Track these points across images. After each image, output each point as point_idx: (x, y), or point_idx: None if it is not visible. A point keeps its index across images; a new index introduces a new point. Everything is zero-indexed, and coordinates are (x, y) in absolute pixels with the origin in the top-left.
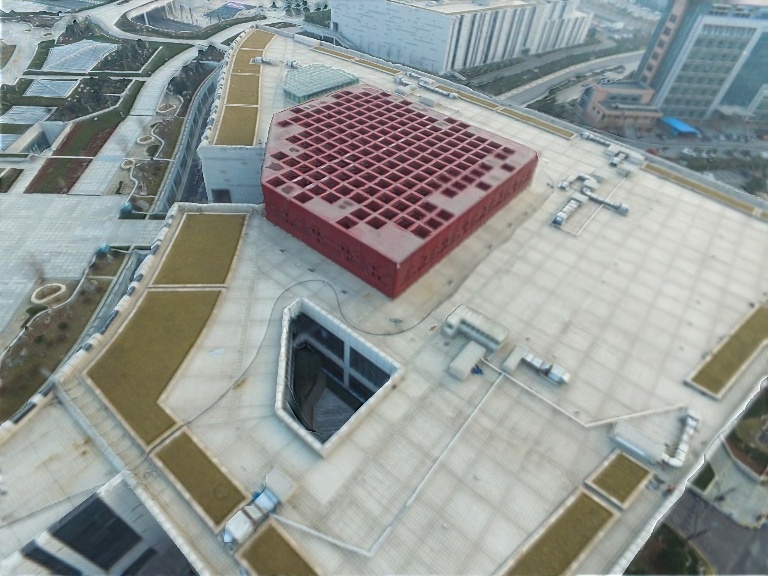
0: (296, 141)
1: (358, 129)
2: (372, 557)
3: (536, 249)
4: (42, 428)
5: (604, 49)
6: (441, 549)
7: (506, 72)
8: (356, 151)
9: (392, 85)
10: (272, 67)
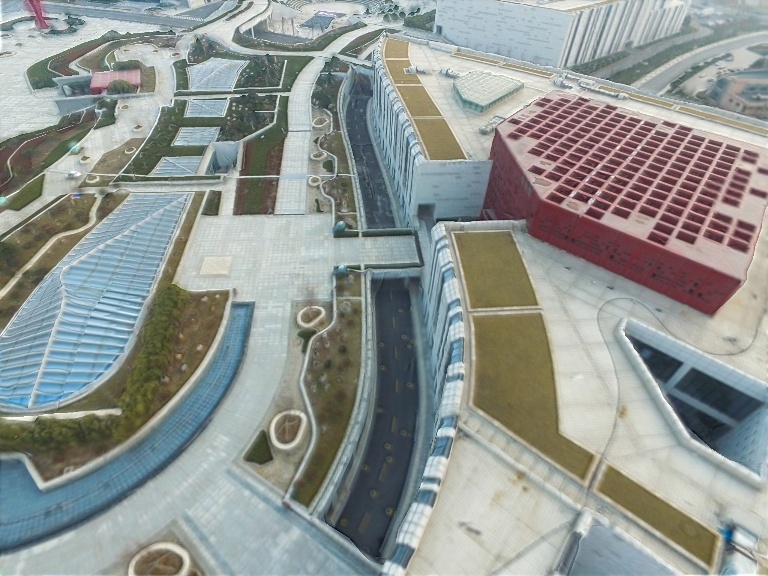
0: (539, 154)
1: (588, 138)
2: None
3: None
4: (468, 463)
5: (703, 37)
6: None
7: (618, 67)
8: (604, 161)
9: (554, 88)
10: (427, 76)
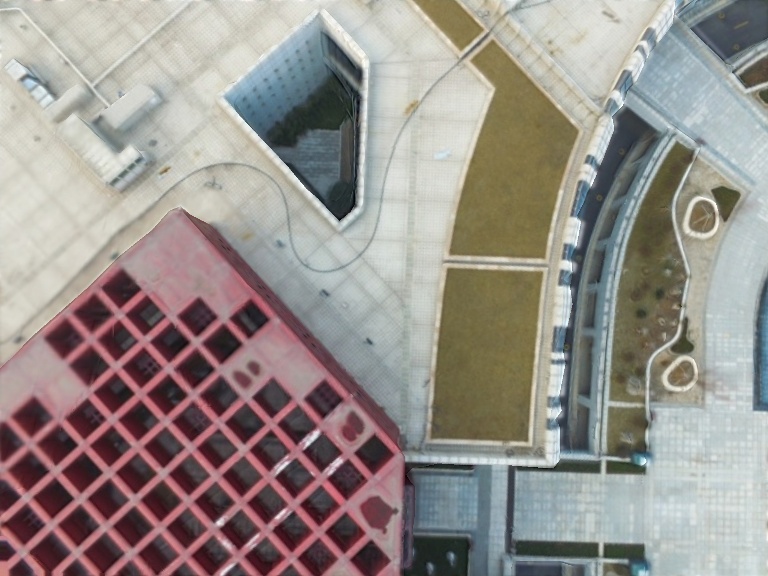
0: None
1: None
2: None
3: None
4: (598, 72)
5: None
6: None
7: None
8: None
9: None
10: None
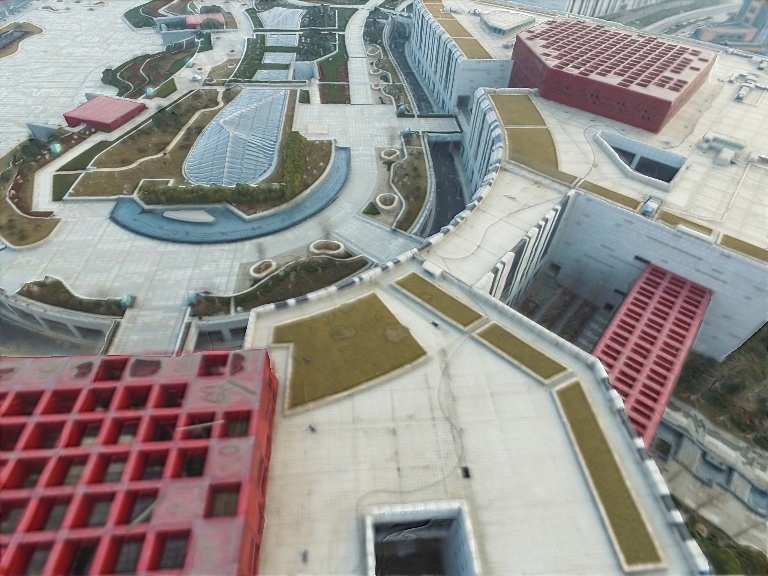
0: (548, 47)
1: (582, 41)
2: (724, 222)
3: (732, 112)
4: (507, 178)
5: (690, 4)
6: (759, 221)
7: None
8: (593, 52)
9: None
10: (459, 15)
